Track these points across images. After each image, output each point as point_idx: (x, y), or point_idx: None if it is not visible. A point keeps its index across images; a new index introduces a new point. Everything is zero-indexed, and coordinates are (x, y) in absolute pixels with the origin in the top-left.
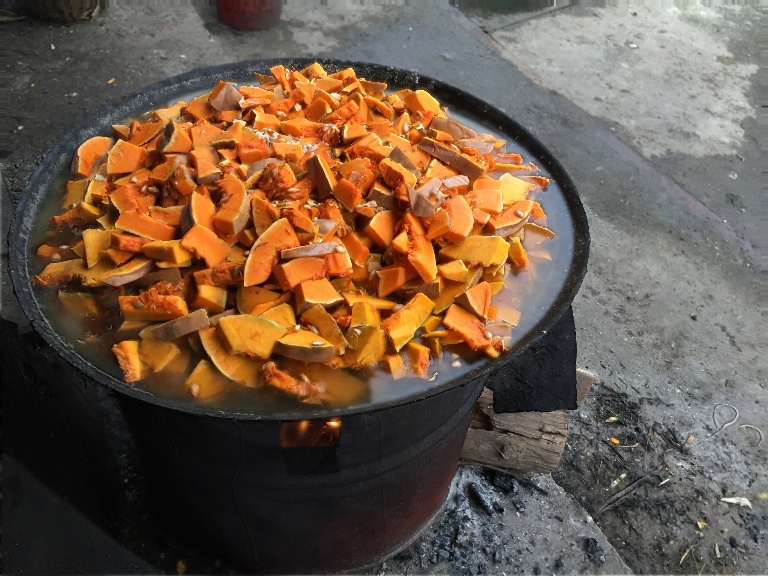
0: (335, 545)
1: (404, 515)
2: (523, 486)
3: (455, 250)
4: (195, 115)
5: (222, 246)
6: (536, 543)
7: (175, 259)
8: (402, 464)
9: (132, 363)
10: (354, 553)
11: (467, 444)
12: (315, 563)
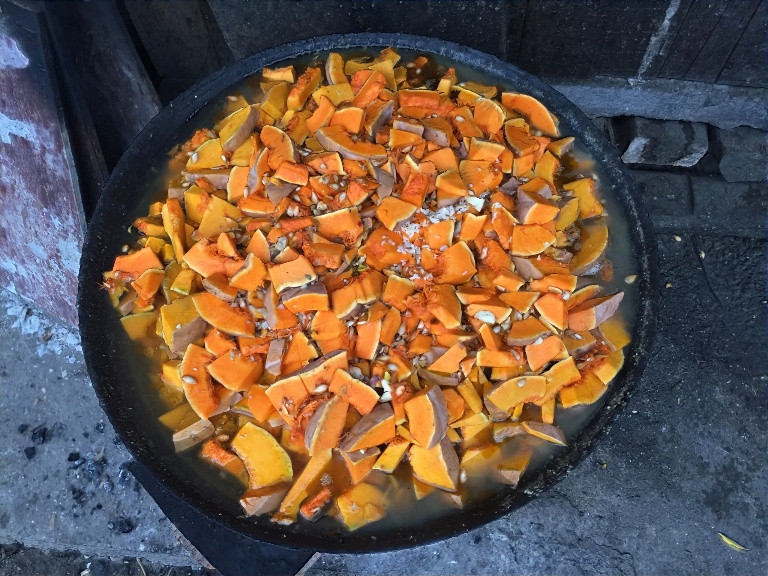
0: None
1: None
2: None
3: None
4: (527, 183)
5: None
6: None
7: None
8: None
9: (275, 74)
10: None
11: None
12: None
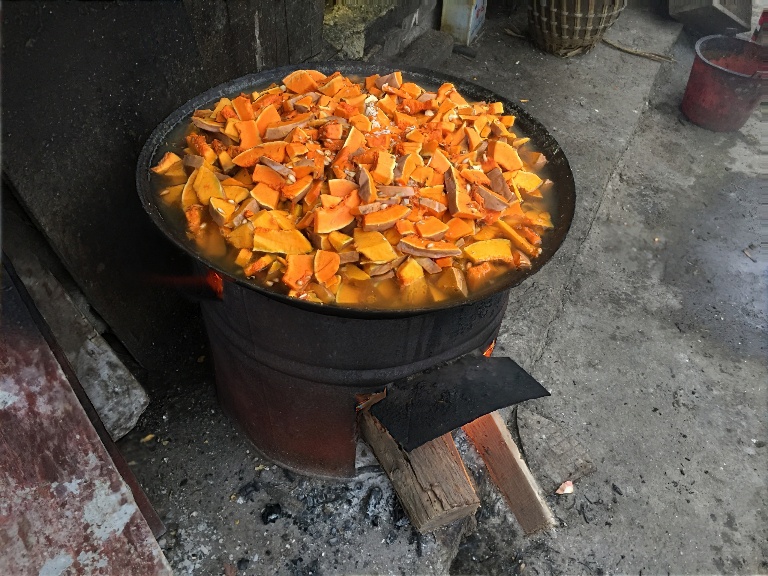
0: (242, 407)
1: (287, 430)
2: (412, 533)
3: (360, 232)
4: (367, 84)
5: (258, 141)
6: (368, 567)
7: (225, 129)
8: (268, 364)
9: (164, 164)
10: (255, 430)
11: (380, 444)
12: (236, 415)
